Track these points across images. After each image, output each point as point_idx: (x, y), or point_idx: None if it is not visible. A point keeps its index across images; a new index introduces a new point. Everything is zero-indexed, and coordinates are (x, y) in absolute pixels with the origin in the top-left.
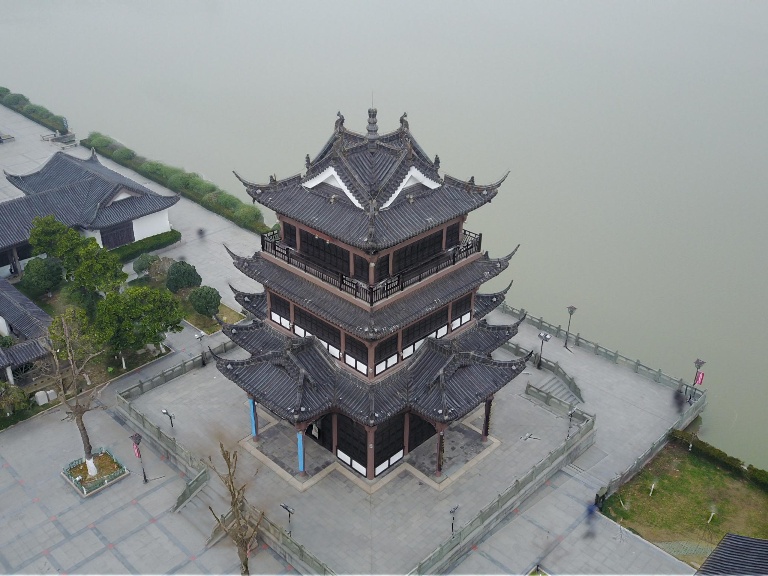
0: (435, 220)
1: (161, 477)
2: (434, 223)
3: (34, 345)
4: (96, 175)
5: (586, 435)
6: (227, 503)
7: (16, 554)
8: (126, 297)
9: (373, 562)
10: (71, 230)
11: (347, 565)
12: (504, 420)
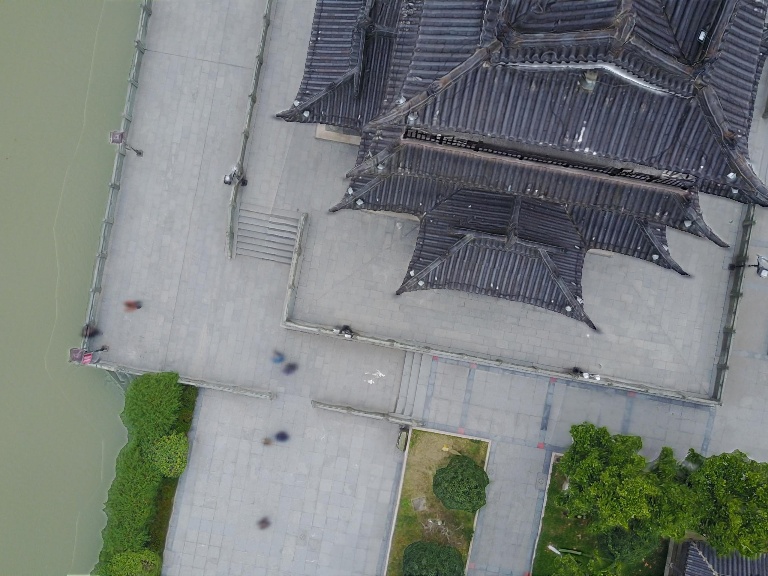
0: None
1: None
2: None
3: (754, 575)
4: None
5: None
6: (767, 143)
7: None
8: (581, 567)
9: None
10: None
11: None
12: None
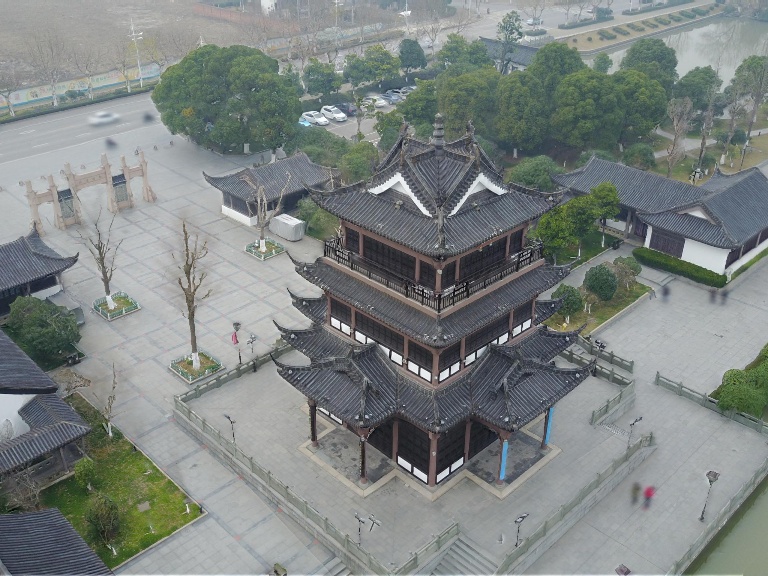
0: (383, 229)
1: None
2: (379, 230)
3: None
4: (718, 190)
5: (378, 575)
6: None
7: (281, 282)
8: None
9: (227, 409)
10: (589, 196)
11: (228, 397)
12: (404, 505)
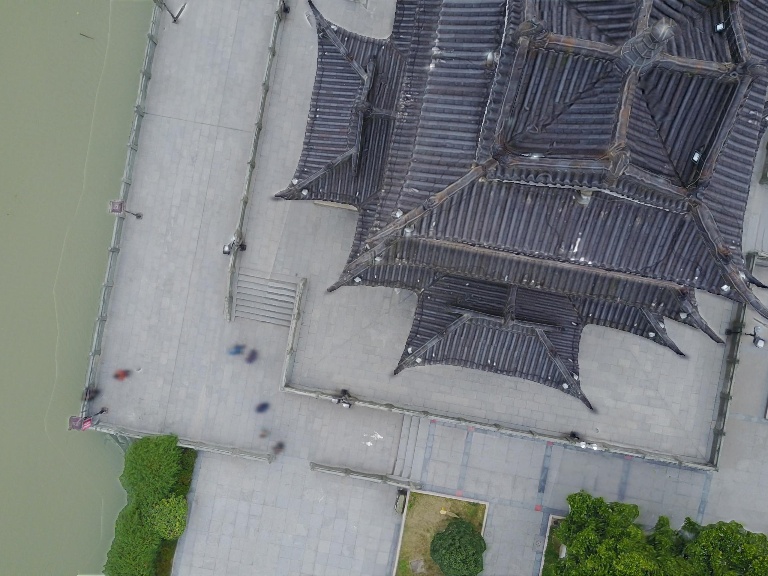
0: None
1: (759, 322)
2: None
3: None
4: None
5: None
6: (764, 208)
7: None
8: None
9: None
10: None
11: None
12: None
